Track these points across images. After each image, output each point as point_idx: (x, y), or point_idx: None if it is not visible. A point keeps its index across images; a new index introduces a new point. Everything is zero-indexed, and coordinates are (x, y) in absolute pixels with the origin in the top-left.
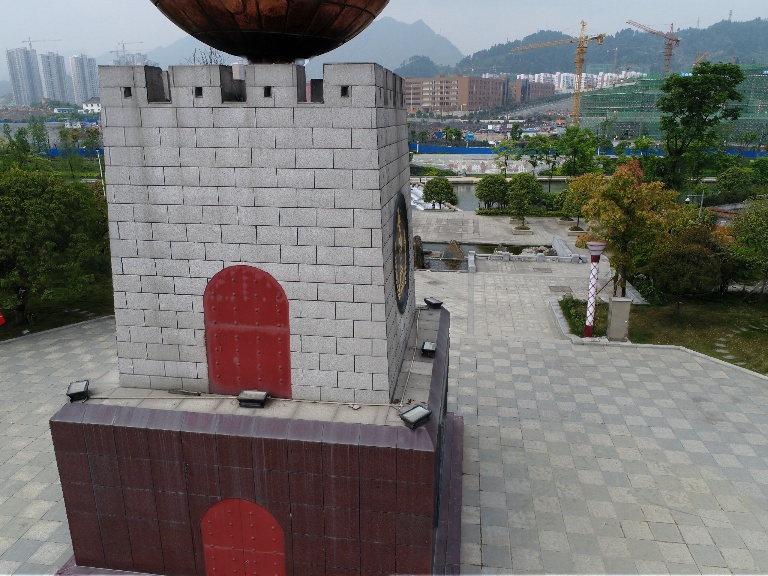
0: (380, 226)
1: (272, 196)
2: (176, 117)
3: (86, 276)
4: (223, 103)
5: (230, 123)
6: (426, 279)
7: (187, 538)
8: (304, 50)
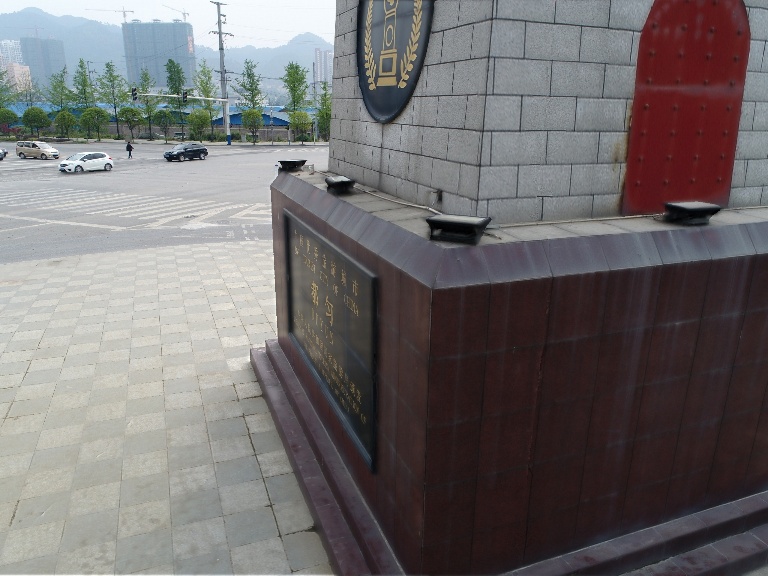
0: None
1: None
2: None
3: None
4: None
5: None
6: None
7: None
8: None
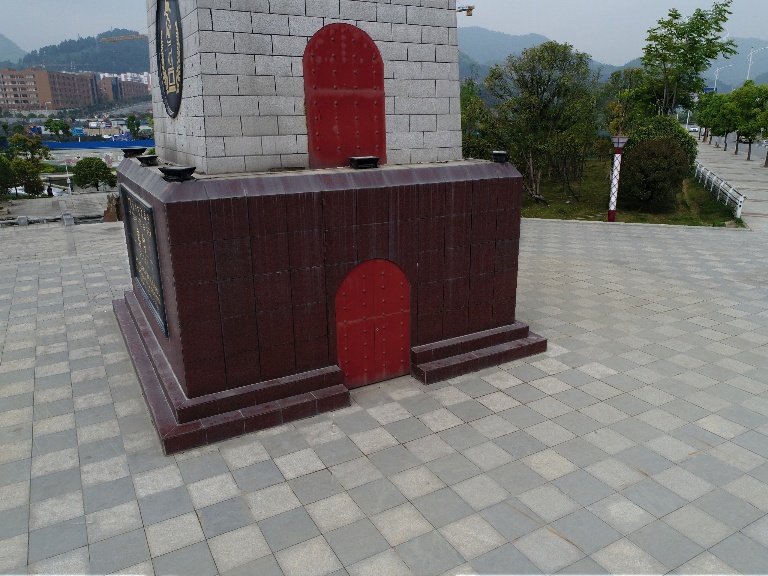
0: None
1: None
2: None
3: None
4: None
5: None
6: None
7: (322, 320)
8: None
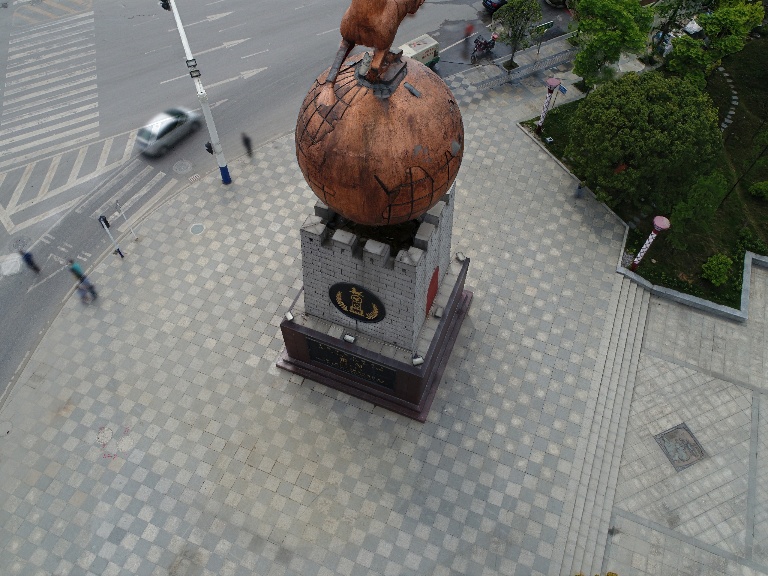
0: None
1: None
2: None
3: (603, 195)
4: None
5: None
6: None
7: None
8: None
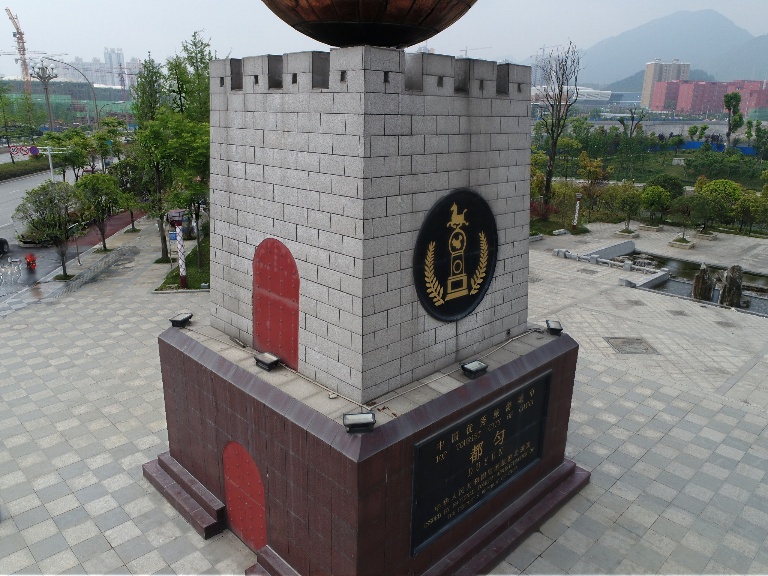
0: (362, 217)
1: (293, 177)
2: (244, 102)
3: None
4: (269, 90)
5: (272, 108)
6: (718, 318)
7: (216, 464)
8: (379, 38)
